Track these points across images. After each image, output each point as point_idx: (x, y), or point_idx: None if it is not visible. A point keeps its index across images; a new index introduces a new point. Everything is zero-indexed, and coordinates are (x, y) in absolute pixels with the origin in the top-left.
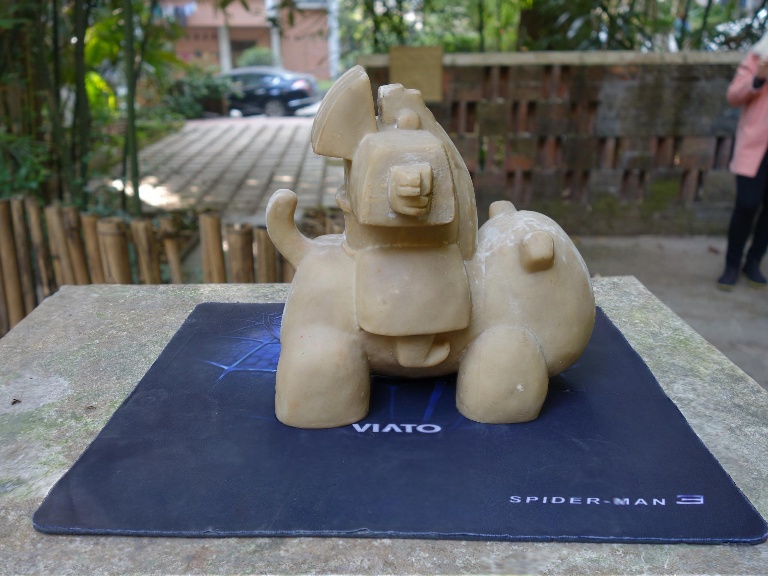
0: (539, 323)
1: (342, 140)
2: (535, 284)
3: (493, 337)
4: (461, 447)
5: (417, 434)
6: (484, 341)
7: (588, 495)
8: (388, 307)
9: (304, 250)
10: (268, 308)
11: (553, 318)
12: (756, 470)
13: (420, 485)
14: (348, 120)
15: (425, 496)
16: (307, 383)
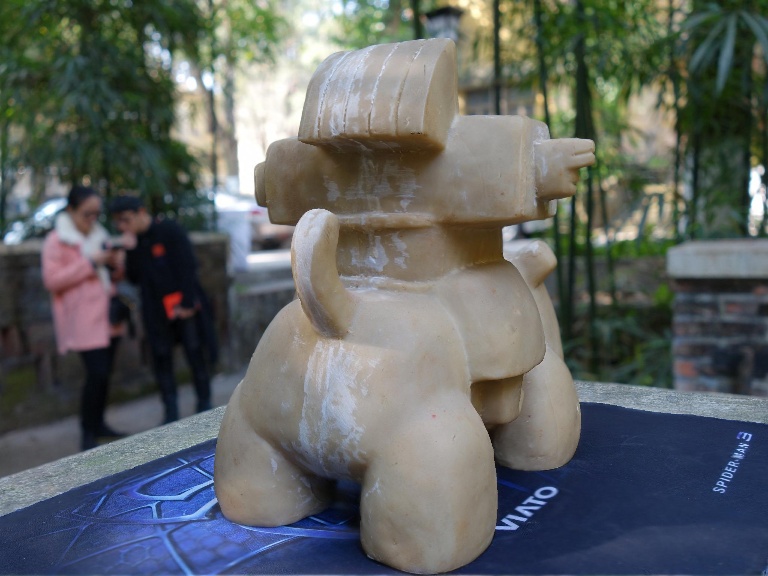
0: (552, 340)
1: (441, 118)
2: (541, 298)
3: (546, 361)
4: (602, 487)
5: (554, 500)
6: (541, 368)
7: (723, 463)
8: (518, 334)
9: (353, 300)
10: (48, 509)
11: (556, 332)
12: (704, 413)
13: (672, 523)
14: (445, 92)
15: (697, 526)
16: (473, 479)
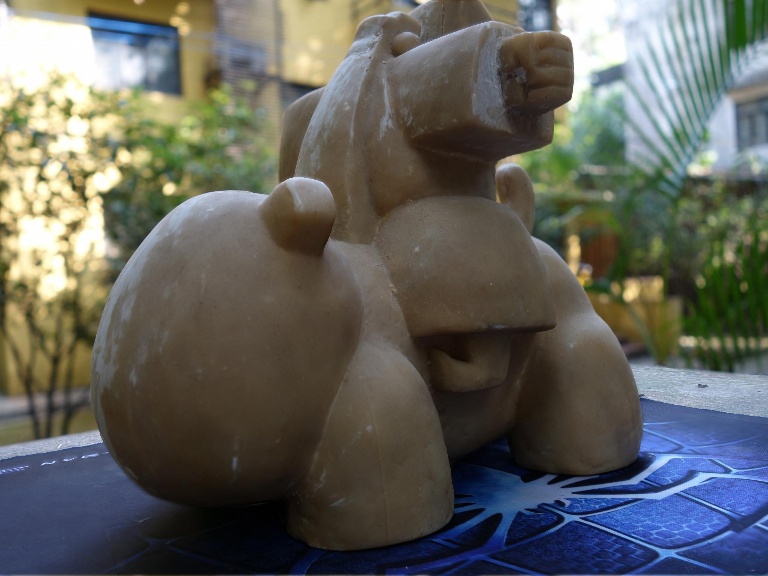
0: None
1: None
2: None
3: None
4: None
5: None
6: None
7: None
8: None
9: None
10: None
11: None
12: None
13: None
14: None
15: None
16: None
